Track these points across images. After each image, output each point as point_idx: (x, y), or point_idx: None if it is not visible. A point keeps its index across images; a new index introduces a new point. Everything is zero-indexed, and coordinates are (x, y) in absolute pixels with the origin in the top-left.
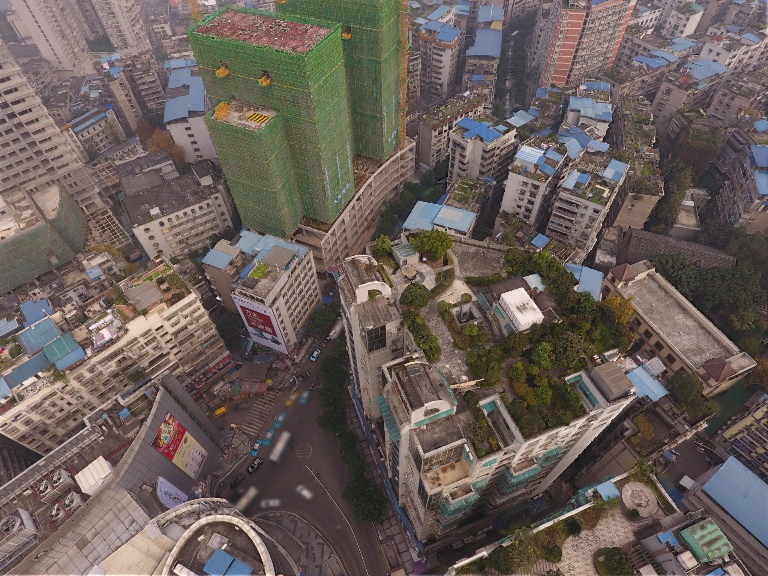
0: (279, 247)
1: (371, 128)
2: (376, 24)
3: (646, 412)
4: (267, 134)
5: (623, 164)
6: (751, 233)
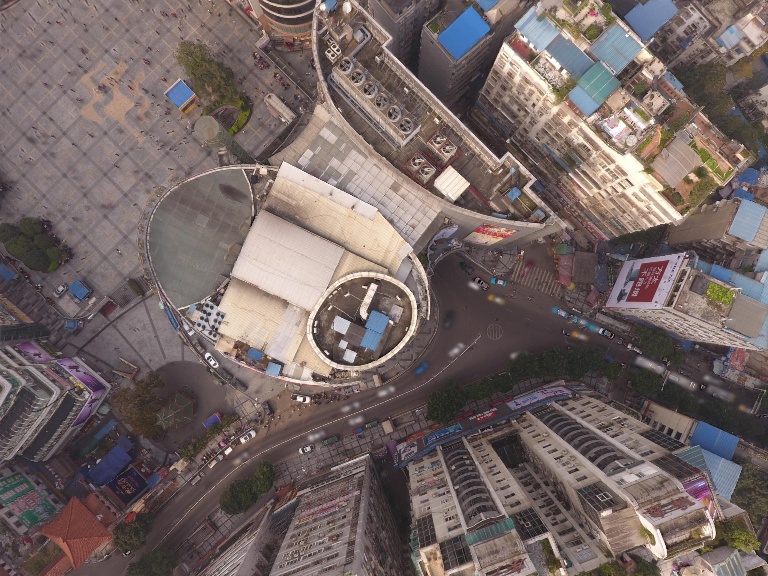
0: (766, 314)
1: None
2: None
3: None
4: None
5: None
6: None
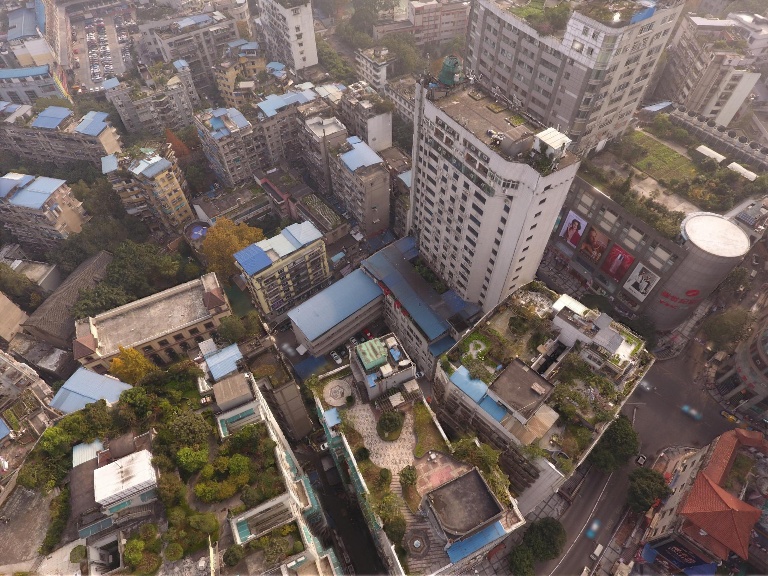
0: None
1: None
2: None
3: (250, 366)
4: None
5: None
6: (78, 230)
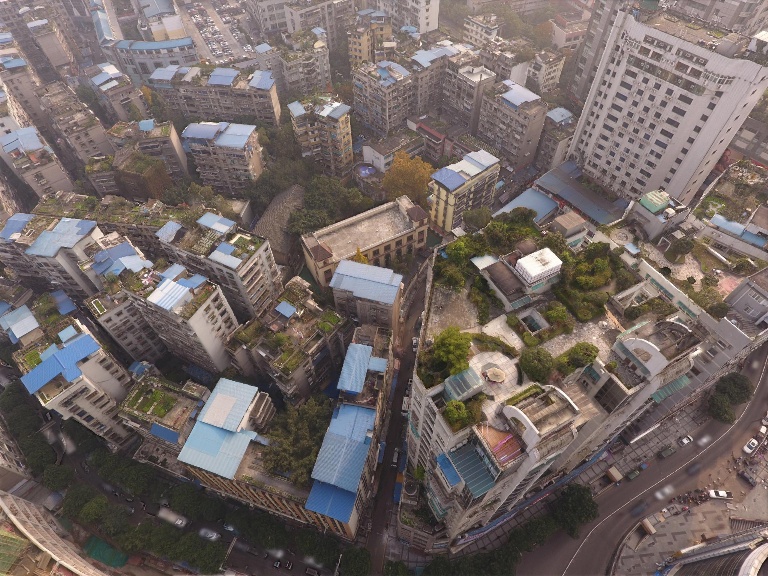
0: None
1: None
2: None
3: None
4: None
5: (207, 215)
6: (259, 173)
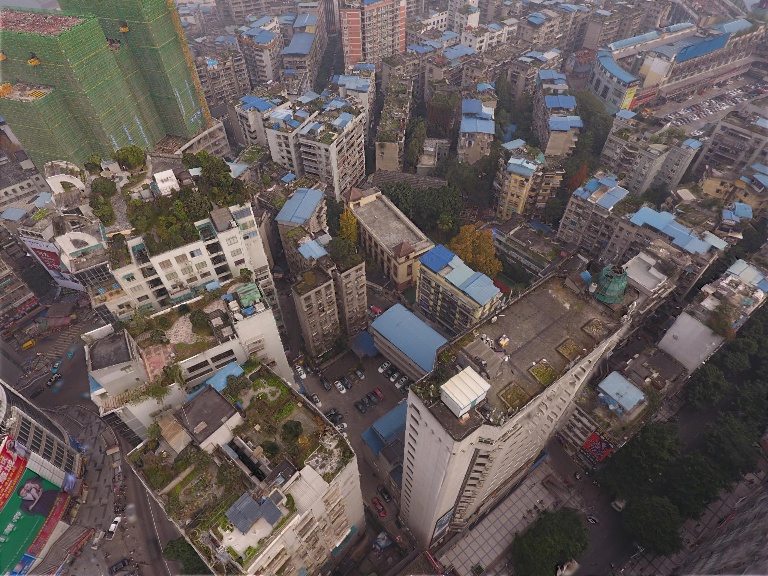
0: None
1: (170, 109)
2: (143, 18)
3: (314, 269)
4: (44, 105)
5: (351, 115)
6: None
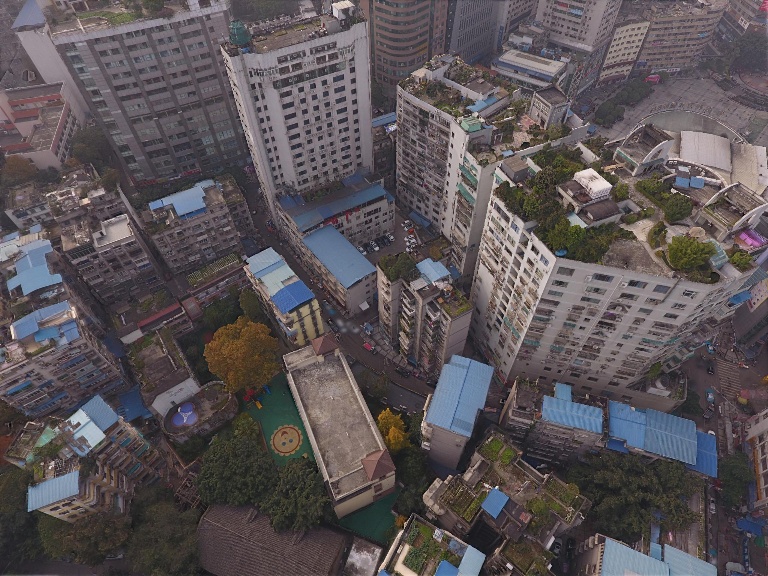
0: None
1: None
2: None
3: None
4: None
5: None
6: None
